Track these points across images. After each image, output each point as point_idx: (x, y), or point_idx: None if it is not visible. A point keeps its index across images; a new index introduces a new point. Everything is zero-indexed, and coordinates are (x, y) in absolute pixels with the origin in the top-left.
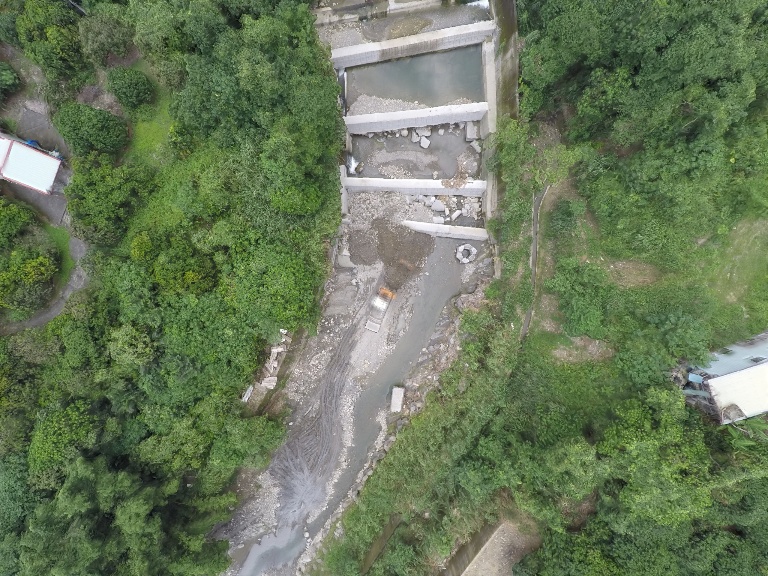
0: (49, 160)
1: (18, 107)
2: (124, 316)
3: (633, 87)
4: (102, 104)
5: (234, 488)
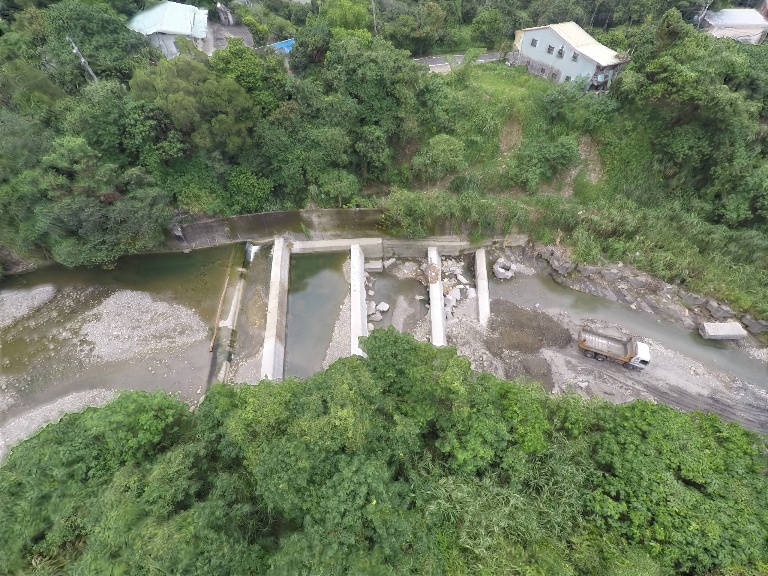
0: None
1: None
2: None
3: (378, 122)
4: None
5: None
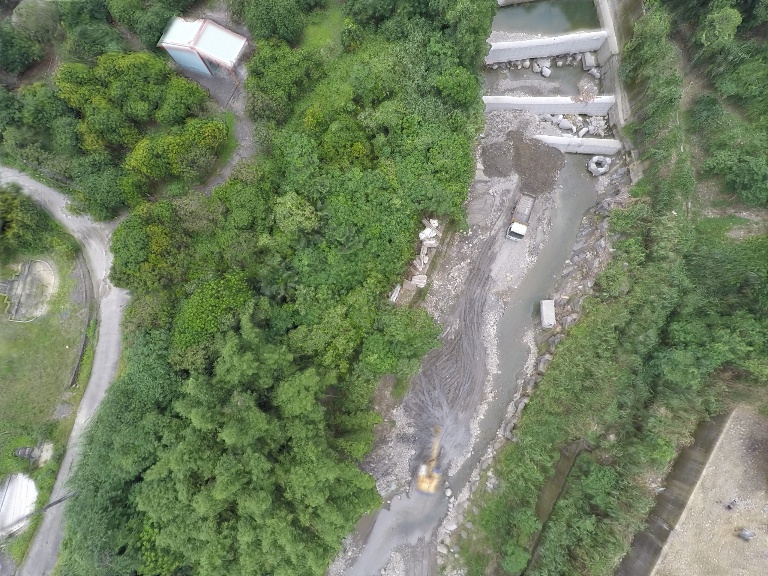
0: (236, 37)
1: (198, 13)
2: (288, 185)
3: None
4: None
5: None
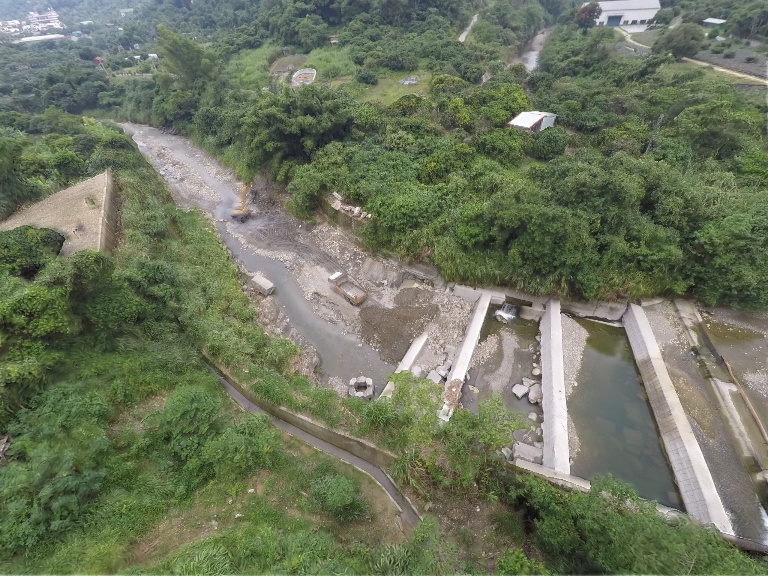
0: None
1: None
2: None
3: None
4: None
5: (284, 193)
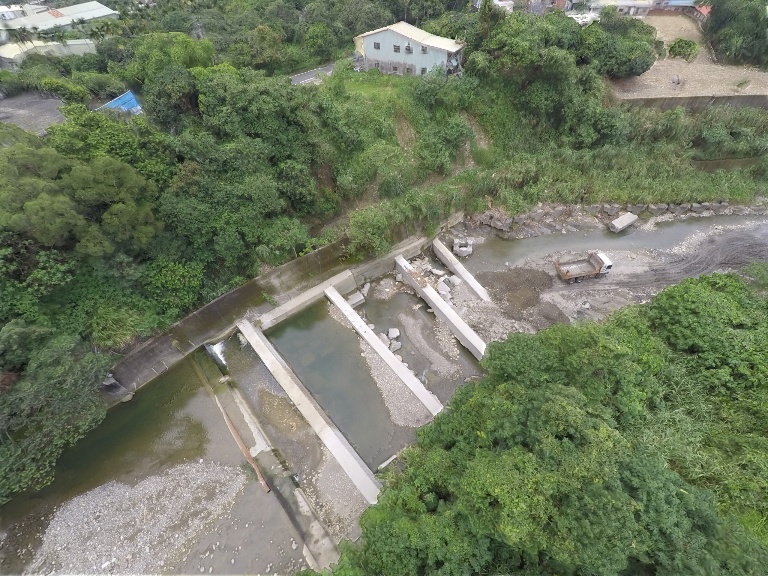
0: None
1: None
2: None
3: (291, 156)
4: None
5: None
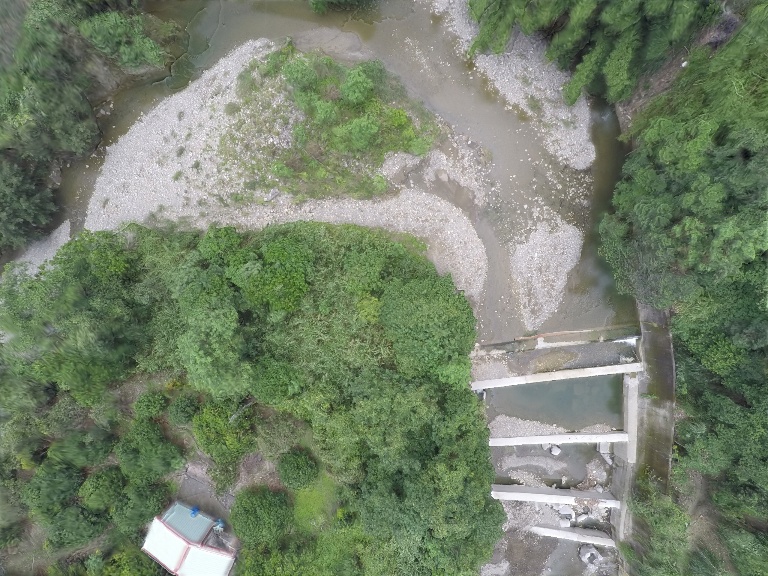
0: (224, 559)
1: None
2: None
3: None
4: (264, 474)
5: None
